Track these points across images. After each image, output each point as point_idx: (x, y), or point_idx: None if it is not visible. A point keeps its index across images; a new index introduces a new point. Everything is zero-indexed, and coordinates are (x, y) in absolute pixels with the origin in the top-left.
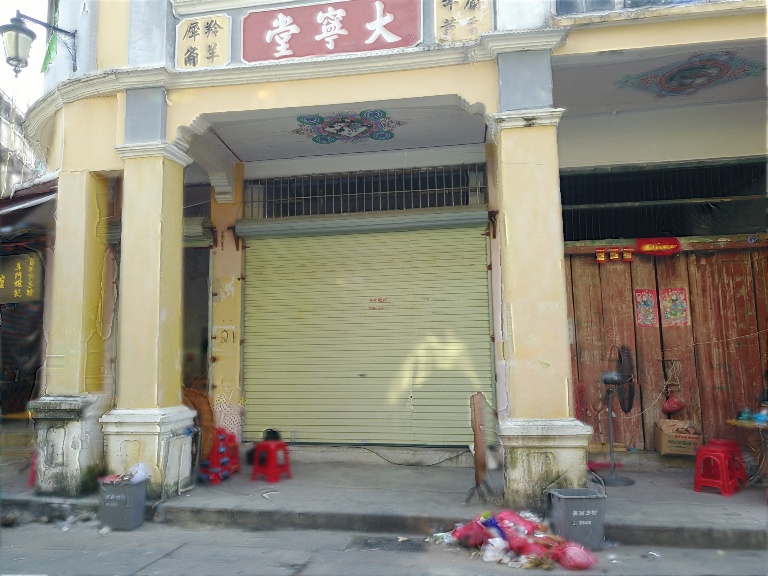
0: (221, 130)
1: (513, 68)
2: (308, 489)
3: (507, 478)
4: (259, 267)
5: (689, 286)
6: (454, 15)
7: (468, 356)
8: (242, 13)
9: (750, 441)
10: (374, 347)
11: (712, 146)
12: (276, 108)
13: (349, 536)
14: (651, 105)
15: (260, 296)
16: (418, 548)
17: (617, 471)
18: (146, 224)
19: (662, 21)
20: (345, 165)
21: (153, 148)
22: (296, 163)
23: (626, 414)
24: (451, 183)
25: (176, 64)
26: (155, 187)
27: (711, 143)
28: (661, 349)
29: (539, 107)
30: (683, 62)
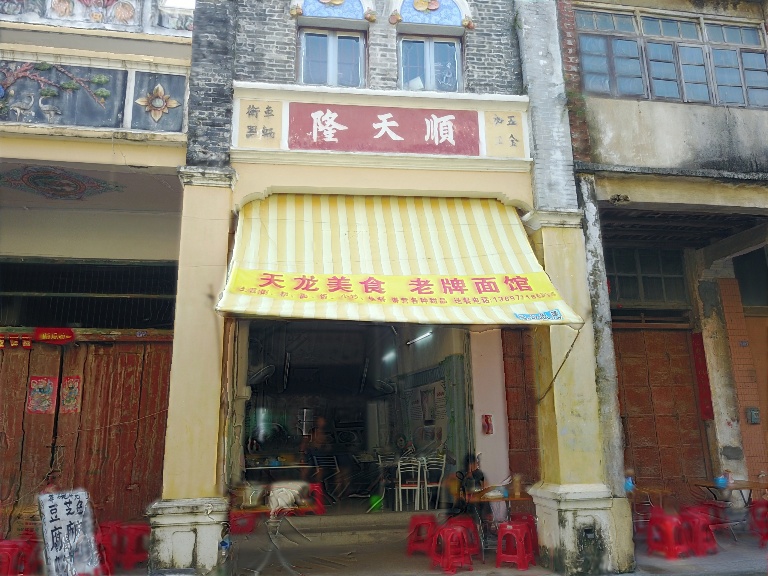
0: None
1: None
2: None
3: None
4: None
5: (84, 375)
6: None
7: None
8: None
9: (109, 524)
10: None
11: (116, 248)
12: None
13: None
14: (55, 205)
15: None
16: None
17: None
18: None
19: None
20: None
21: None
22: None
23: (2, 502)
24: None
25: None
26: None
27: (115, 245)
28: (53, 435)
29: None
30: (23, 171)
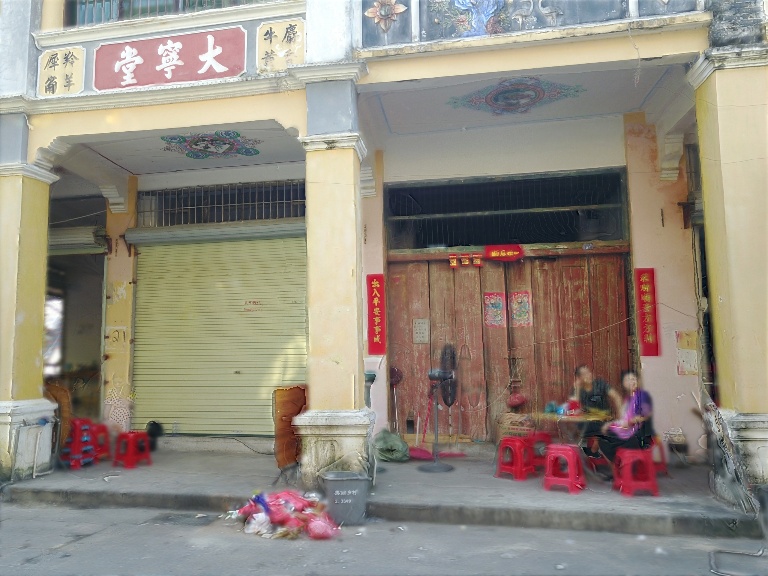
0: (98, 148)
1: (318, 97)
2: (150, 474)
3: (299, 463)
4: (148, 272)
5: (532, 290)
6: (273, 48)
7: None
8: (94, 45)
9: None
10: (250, 346)
11: (552, 160)
12: (121, 132)
13: (158, 513)
14: (494, 122)
15: (147, 299)
16: (205, 523)
17: (454, 460)
18: (6, 236)
19: (450, 54)
20: (225, 178)
21: (13, 168)
22: (181, 176)
23: (473, 408)
24: None
25: (38, 92)
26: (15, 203)
27: (551, 157)
28: (508, 348)
29: (339, 132)
30: (496, 86)
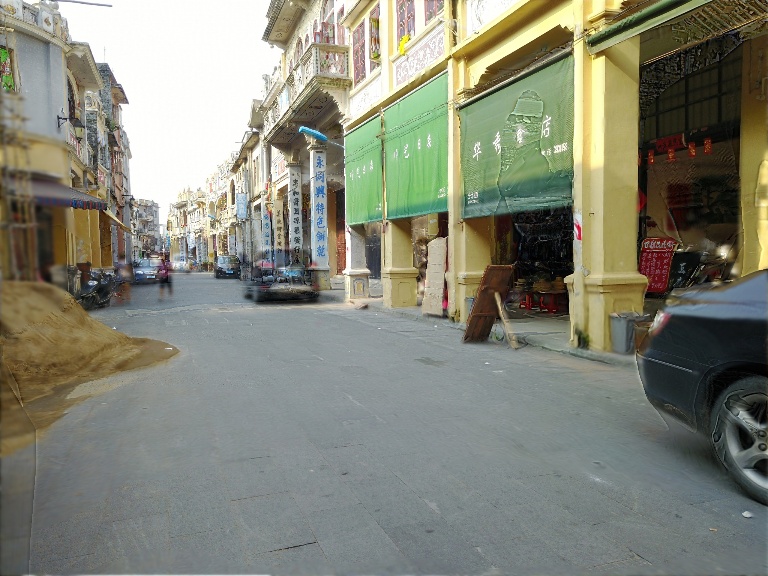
0: None
1: None
2: None
3: None
4: None
5: None
6: None
7: None
8: None
9: None
10: None
11: None
12: None
13: None
14: None
15: None
16: None
17: None
18: None
19: None
20: None
21: None
22: None
23: None
24: None
25: None
26: None
27: None
28: None
29: None
30: None
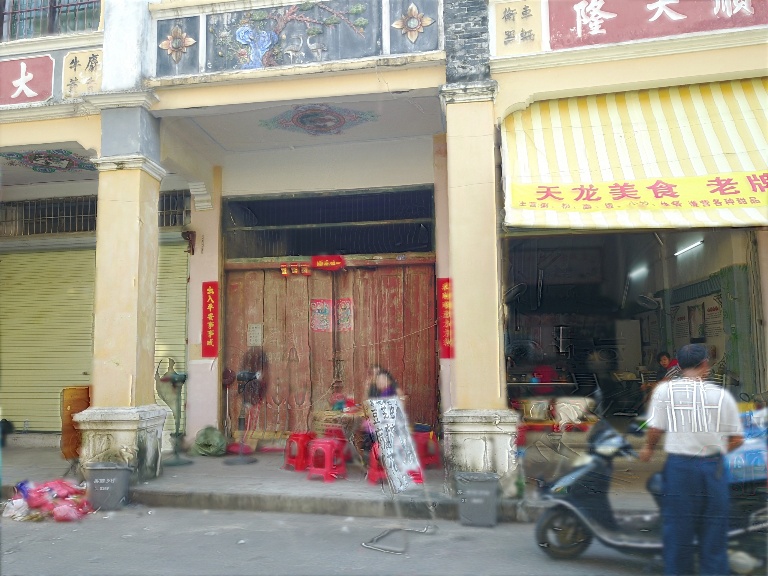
0: None
1: (111, 122)
2: None
3: (80, 455)
4: (6, 278)
5: (353, 297)
6: (77, 76)
7: (169, 356)
8: None
9: None
10: None
11: (371, 177)
12: None
13: None
14: (316, 142)
15: (3, 304)
16: None
17: (271, 454)
18: None
19: (229, 84)
20: (78, 190)
21: None
22: (37, 188)
23: (299, 406)
24: (163, 207)
25: None
26: None
27: (370, 174)
28: (333, 351)
29: (127, 154)
30: (294, 112)
